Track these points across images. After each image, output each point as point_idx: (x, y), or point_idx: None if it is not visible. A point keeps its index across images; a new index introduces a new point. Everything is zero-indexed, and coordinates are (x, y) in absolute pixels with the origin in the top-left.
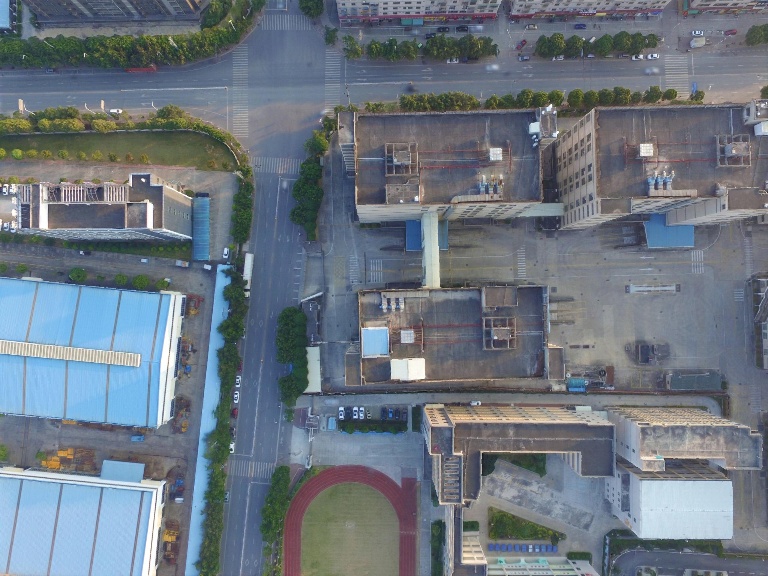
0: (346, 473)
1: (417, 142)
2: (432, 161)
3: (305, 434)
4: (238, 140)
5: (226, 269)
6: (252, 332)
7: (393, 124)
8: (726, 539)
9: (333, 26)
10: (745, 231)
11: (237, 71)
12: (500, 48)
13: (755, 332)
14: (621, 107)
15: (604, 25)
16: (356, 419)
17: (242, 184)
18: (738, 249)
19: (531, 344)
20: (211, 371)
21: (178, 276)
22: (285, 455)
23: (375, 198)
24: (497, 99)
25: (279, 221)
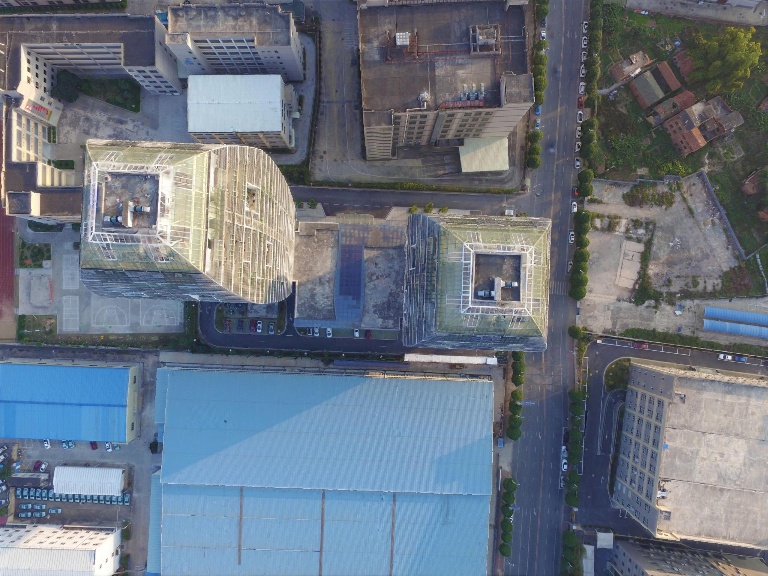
0: None
1: None
2: None
3: None
4: None
5: None
6: None
7: None
8: (275, 132)
9: None
10: None
11: None
12: None
13: None
14: None
15: None
16: None
17: None
18: None
19: None
20: None
21: None
22: None
23: None
24: None
25: None
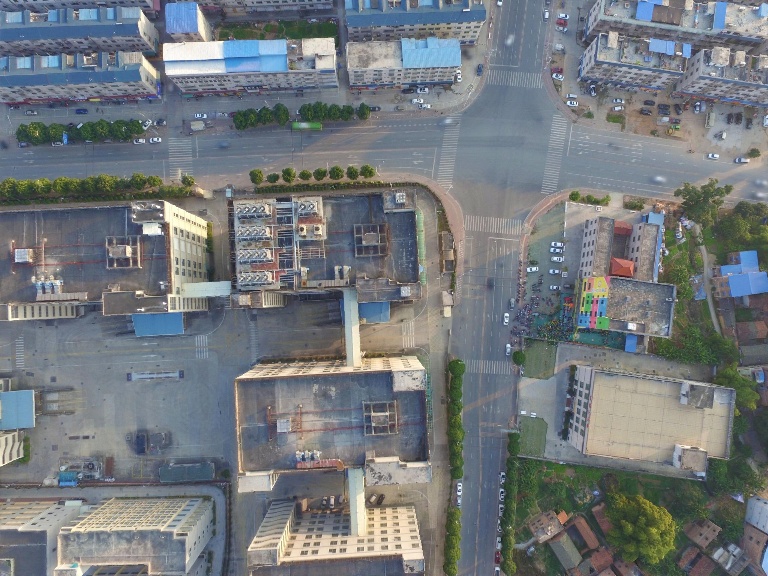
0: None
1: None
2: None
3: None
4: None
5: None
6: None
7: None
8: None
9: None
10: (250, 314)
11: None
12: None
13: None
14: None
15: (107, 109)
16: None
17: None
18: (243, 333)
19: None
20: None
21: None
22: None
23: None
24: None
25: None
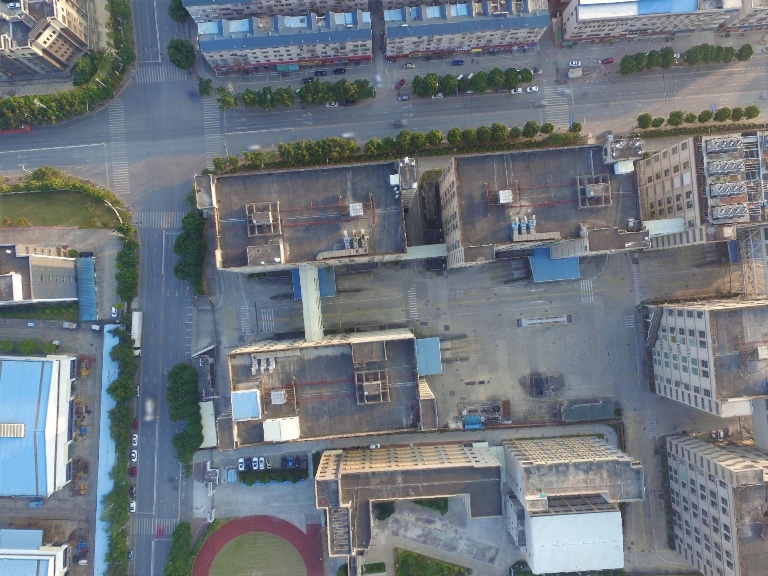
0: (250, 524)
1: (279, 200)
2: (295, 218)
3: (206, 488)
4: (120, 196)
5: (113, 329)
6: (146, 389)
7: (254, 183)
8: (618, 568)
9: (209, 75)
10: (632, 258)
11: (114, 126)
12: (379, 89)
13: (647, 357)
14: (480, 154)
15: (482, 60)
16: (256, 470)
17: (125, 242)
18: (626, 276)
19: (405, 395)
20: (104, 433)
21: (67, 338)
22: (188, 510)
23: (240, 259)
24: (376, 142)
25: (167, 276)
